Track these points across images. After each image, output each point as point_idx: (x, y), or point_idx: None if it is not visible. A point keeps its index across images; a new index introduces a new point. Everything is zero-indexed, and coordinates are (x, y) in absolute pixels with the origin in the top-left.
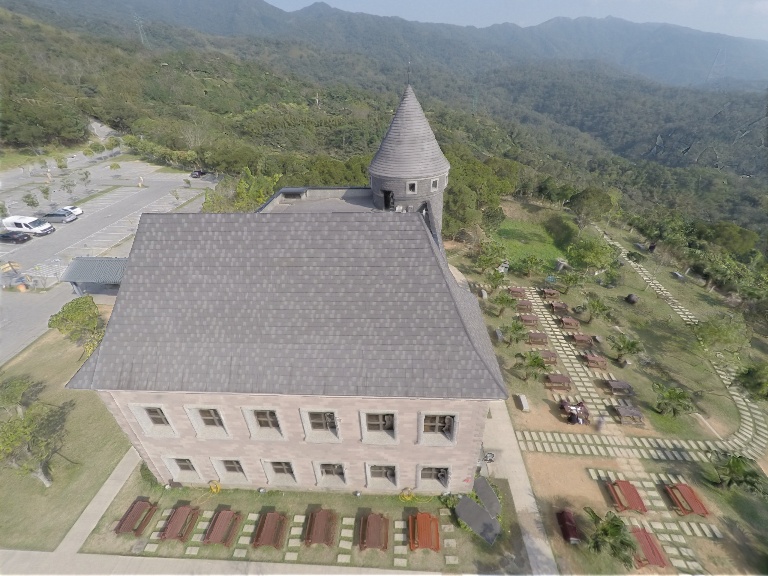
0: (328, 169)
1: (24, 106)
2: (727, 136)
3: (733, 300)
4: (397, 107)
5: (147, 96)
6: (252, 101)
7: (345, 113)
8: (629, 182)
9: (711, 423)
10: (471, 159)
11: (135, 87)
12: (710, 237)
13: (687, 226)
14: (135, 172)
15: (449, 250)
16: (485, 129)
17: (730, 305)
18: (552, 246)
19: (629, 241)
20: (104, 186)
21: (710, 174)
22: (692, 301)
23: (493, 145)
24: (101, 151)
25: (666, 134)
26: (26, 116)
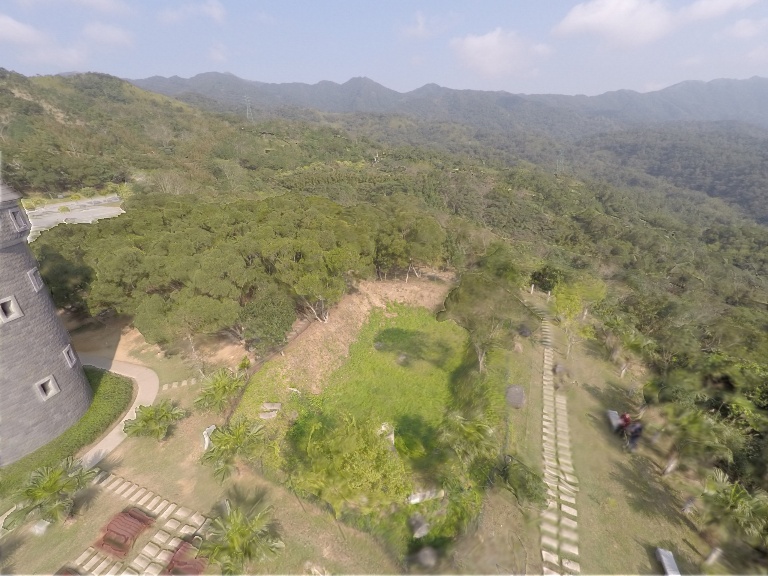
0: (115, 218)
1: (59, 157)
2: None
3: None
4: (463, 166)
5: (214, 154)
6: (310, 159)
7: (399, 170)
8: None
9: None
10: (358, 214)
11: (205, 147)
12: None
13: (765, 387)
14: (95, 216)
15: (206, 365)
16: (560, 189)
17: None
18: (442, 379)
19: (600, 400)
20: (39, 228)
21: None
22: None
23: (564, 206)
24: (90, 196)
25: None
26: (51, 165)
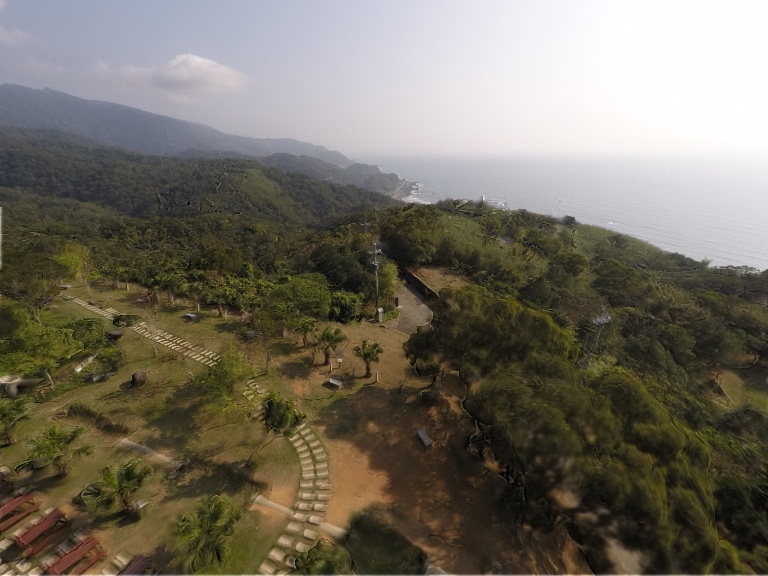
0: None
1: None
2: (210, 188)
3: (247, 316)
4: None
5: None
6: None
7: None
8: (154, 239)
9: (275, 498)
10: None
11: None
12: (207, 265)
13: (183, 262)
14: None
15: None
16: None
17: (247, 322)
18: None
19: (127, 301)
20: None
21: (214, 217)
22: (213, 338)
23: None
24: None
25: (164, 192)
26: None
